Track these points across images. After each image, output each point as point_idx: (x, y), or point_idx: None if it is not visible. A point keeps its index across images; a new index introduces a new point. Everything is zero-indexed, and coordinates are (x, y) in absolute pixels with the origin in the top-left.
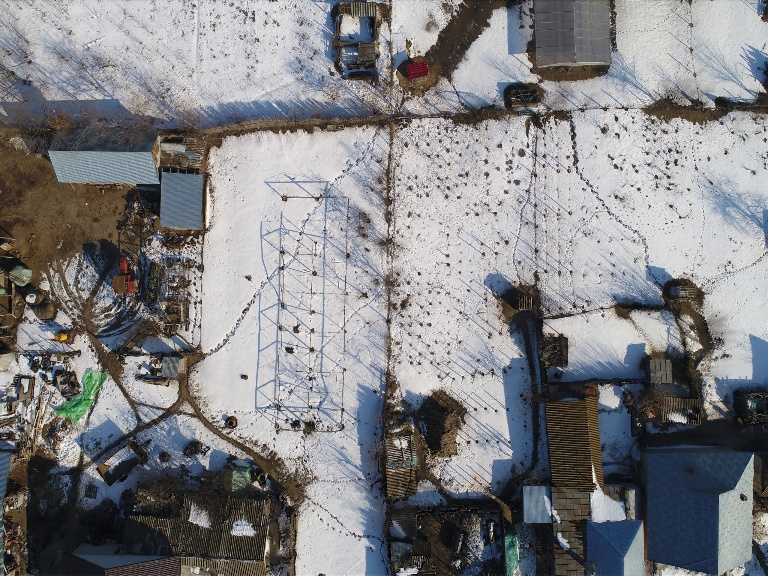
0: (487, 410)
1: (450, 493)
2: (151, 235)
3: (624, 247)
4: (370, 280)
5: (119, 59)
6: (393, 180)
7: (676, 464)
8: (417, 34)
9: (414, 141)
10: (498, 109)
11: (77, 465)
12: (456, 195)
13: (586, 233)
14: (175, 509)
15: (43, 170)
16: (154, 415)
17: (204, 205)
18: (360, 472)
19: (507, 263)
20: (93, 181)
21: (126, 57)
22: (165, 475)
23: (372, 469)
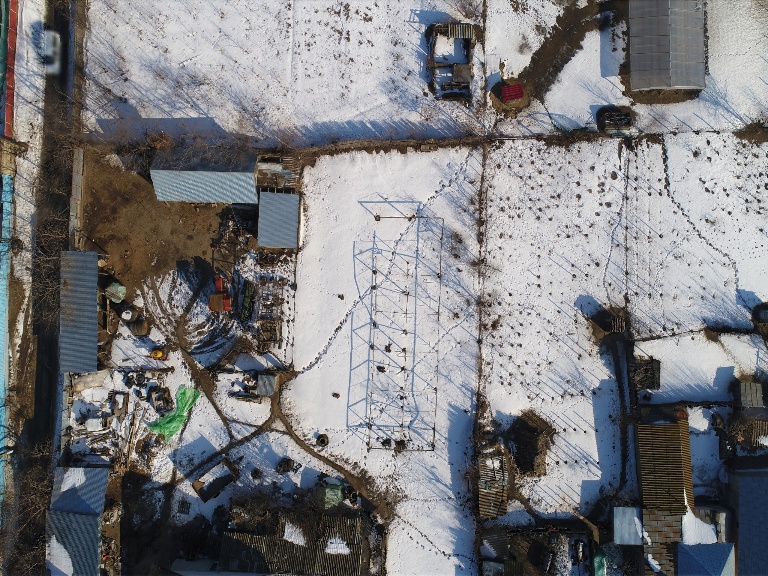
0: (576, 431)
1: (539, 513)
2: (245, 253)
3: (714, 270)
4: (462, 300)
5: (214, 77)
6: (485, 201)
7: None
8: (510, 56)
9: (507, 162)
10: (591, 131)
11: (170, 481)
12: (548, 217)
13: (677, 256)
14: (270, 526)
15: (138, 187)
16: (246, 432)
17: (298, 224)
18: (450, 491)
19: (597, 285)
20: (192, 200)
21: (221, 76)
22: (258, 492)
23: (462, 488)
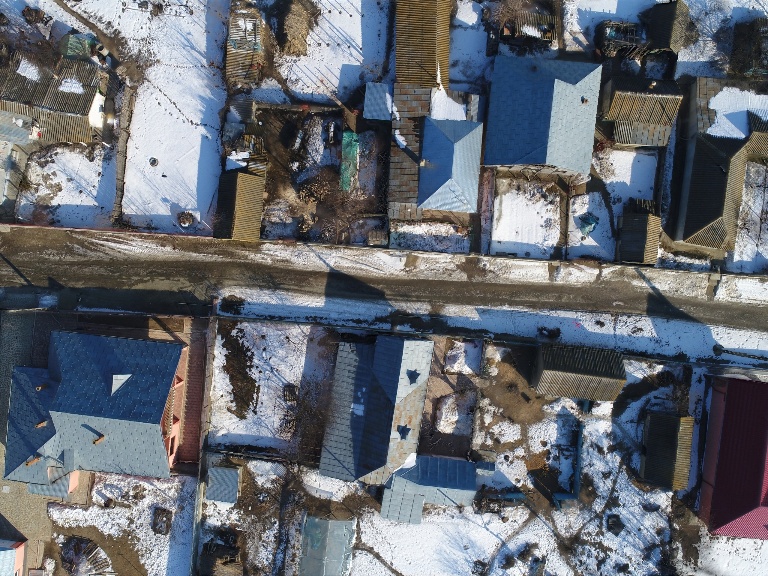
0: (342, 14)
1: (295, 93)
2: None
3: None
4: None
5: None
6: None
7: (521, 64)
8: None
9: None
10: None
11: None
12: None
13: None
14: None
15: None
16: None
17: None
18: (204, 59)
19: None
20: None
21: None
22: (1, 35)
23: (217, 58)
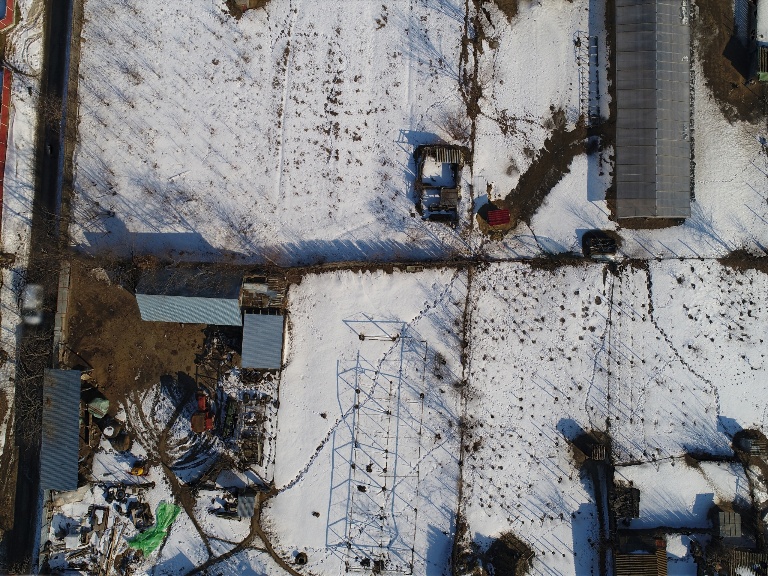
0: (555, 554)
1: None
2: (228, 369)
3: (696, 397)
4: (444, 421)
5: (203, 193)
6: (470, 323)
7: None
8: (498, 178)
9: (492, 285)
10: (576, 256)
11: None
12: (531, 339)
13: (659, 382)
14: None
15: (124, 301)
16: (225, 549)
17: (282, 342)
18: None
19: (579, 408)
20: (176, 321)
21: (210, 191)
22: None
23: None
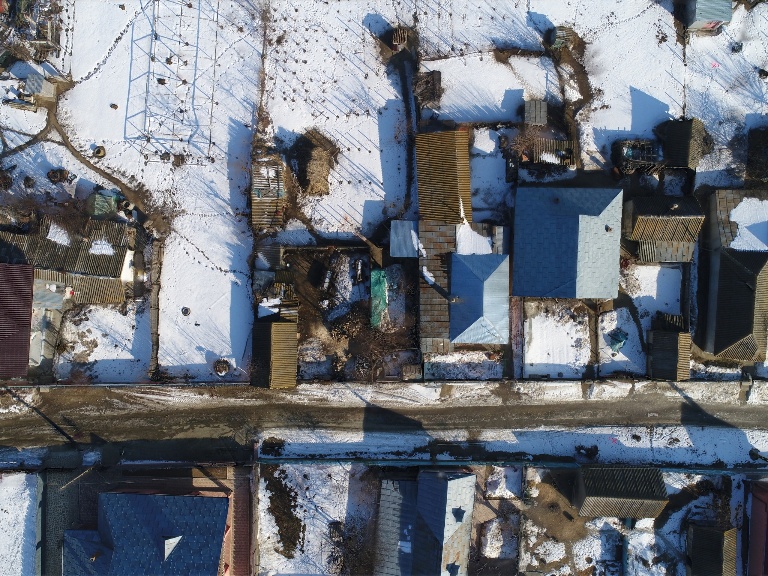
0: (361, 151)
1: (320, 233)
2: None
3: None
4: (246, 14)
5: None
6: None
7: (543, 196)
8: None
9: None
10: None
11: None
12: None
13: None
14: (34, 227)
15: None
16: (21, 141)
17: None
18: (228, 206)
19: (386, 4)
20: None
21: None
22: (28, 199)
23: (241, 204)
